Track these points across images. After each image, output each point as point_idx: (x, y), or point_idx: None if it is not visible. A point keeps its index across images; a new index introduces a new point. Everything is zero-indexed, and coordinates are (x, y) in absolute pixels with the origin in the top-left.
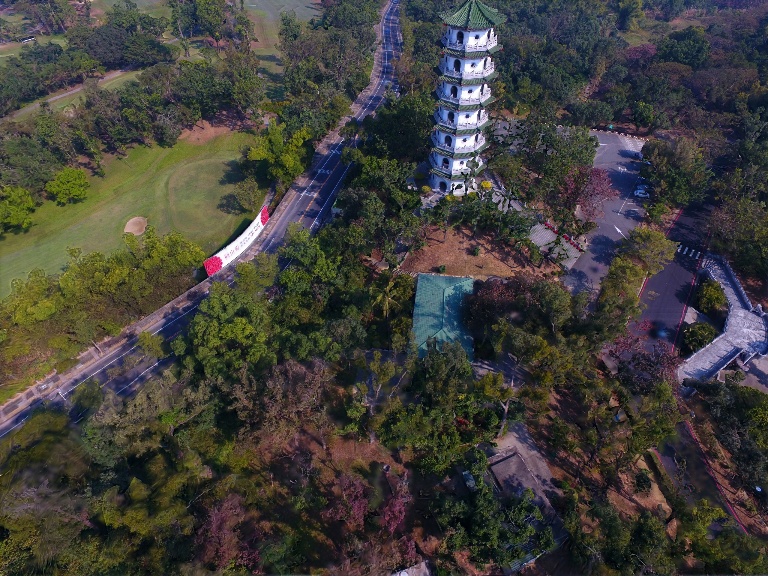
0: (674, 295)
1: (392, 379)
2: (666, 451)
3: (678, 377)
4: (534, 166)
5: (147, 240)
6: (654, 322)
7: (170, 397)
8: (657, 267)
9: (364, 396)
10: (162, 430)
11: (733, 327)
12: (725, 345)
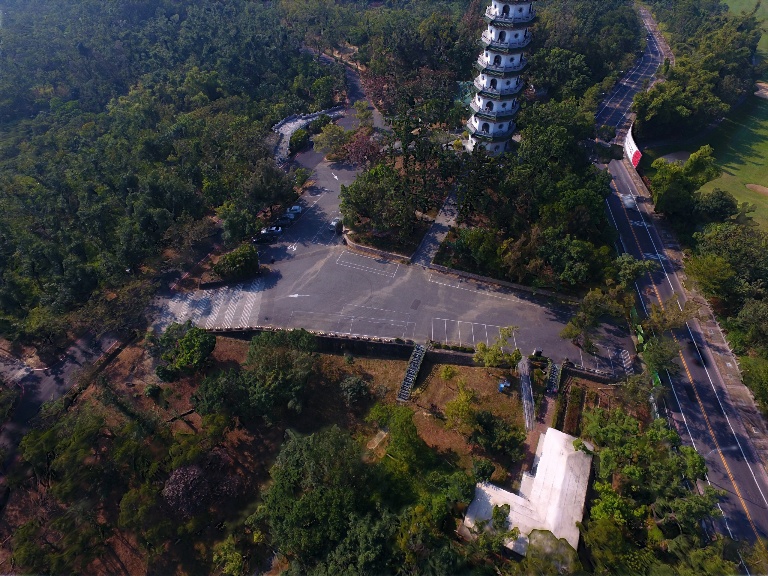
0: None
1: None
2: None
3: None
4: None
5: (668, 92)
6: None
7: (559, 34)
8: None
9: None
10: (551, 26)
11: None
12: None
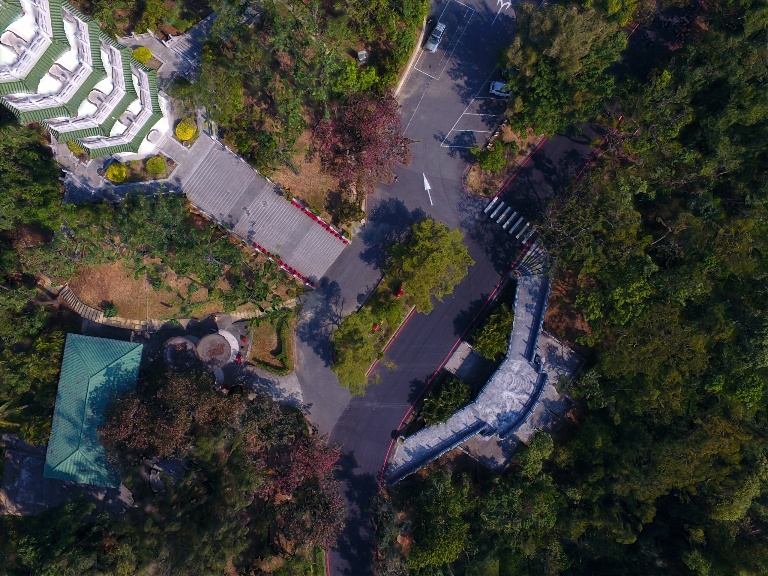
0: (452, 321)
1: (43, 482)
2: (338, 547)
3: (394, 454)
4: (329, 10)
5: None
6: (403, 371)
7: None
8: (422, 308)
9: (12, 503)
10: None
11: (493, 389)
12: (468, 417)
